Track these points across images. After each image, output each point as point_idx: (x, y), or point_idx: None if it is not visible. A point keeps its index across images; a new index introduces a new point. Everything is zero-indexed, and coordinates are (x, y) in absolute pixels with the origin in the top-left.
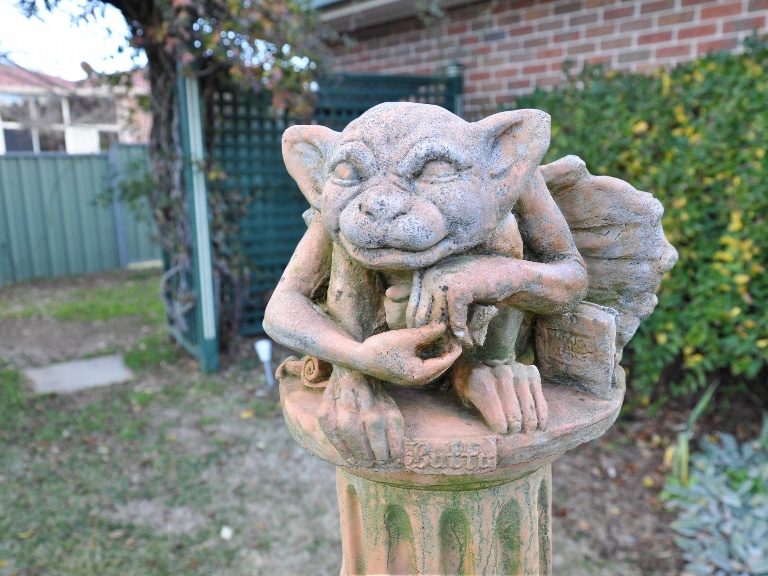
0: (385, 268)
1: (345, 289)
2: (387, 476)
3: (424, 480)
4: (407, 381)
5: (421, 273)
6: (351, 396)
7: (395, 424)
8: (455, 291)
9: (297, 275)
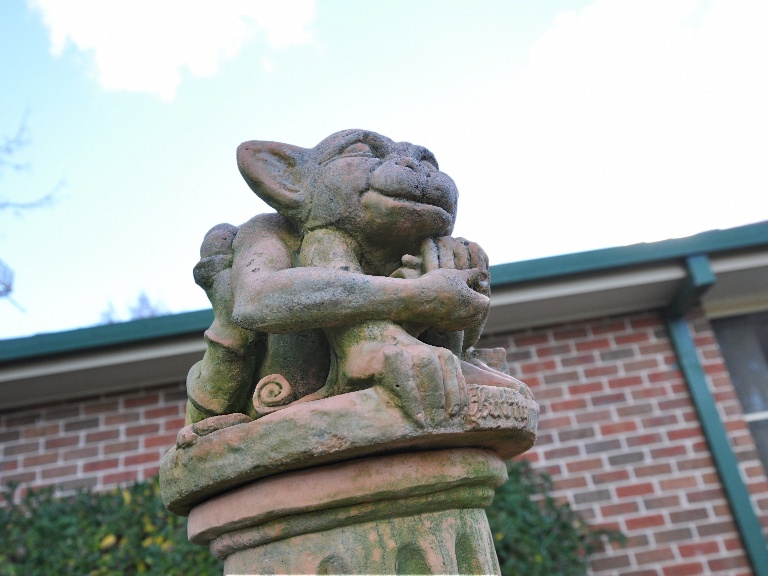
0: (420, 220)
1: (350, 265)
2: (419, 475)
3: (455, 471)
4: (474, 306)
5: (433, 241)
6: (411, 339)
7: (459, 364)
8: (476, 244)
9: (274, 265)
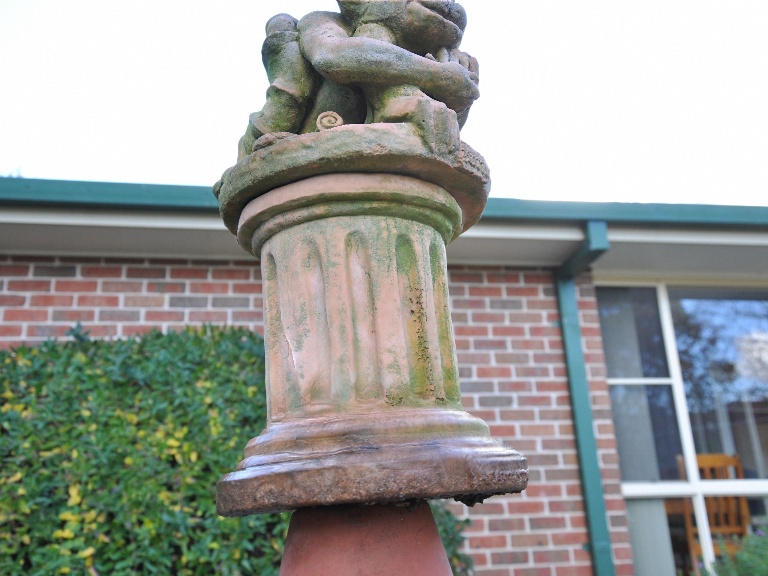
0: (444, 30)
1: None
2: (419, 190)
3: (440, 197)
4: (472, 91)
5: None
6: None
7: None
8: None
9: (342, 37)
